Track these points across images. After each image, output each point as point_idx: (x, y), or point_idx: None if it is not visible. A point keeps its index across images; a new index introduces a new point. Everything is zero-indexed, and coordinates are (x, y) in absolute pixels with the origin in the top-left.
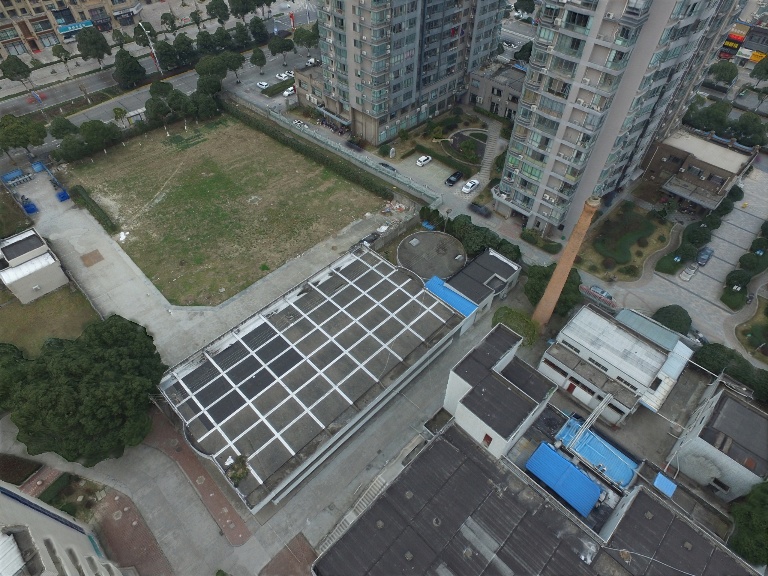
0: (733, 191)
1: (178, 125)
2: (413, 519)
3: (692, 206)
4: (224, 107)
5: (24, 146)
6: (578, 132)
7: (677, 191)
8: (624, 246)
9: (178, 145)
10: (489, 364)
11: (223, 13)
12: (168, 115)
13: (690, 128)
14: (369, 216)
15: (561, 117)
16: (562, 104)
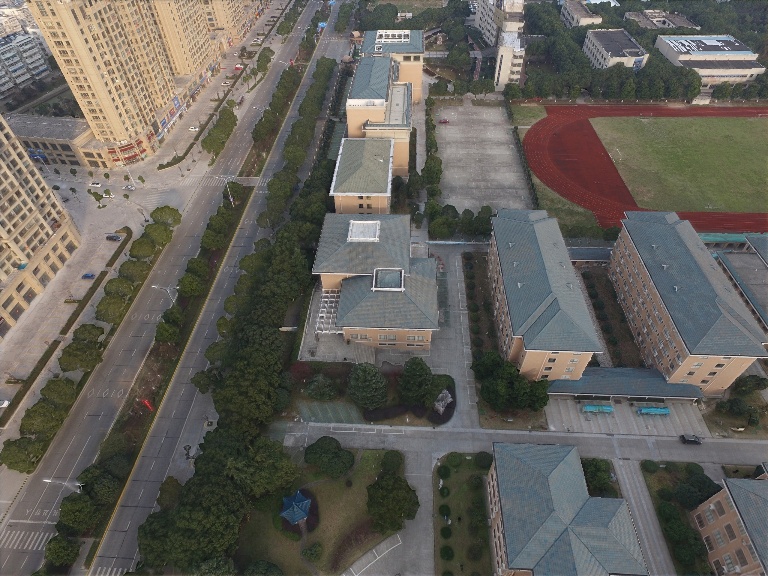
0: None
1: None
2: None
3: None
4: None
5: None
6: None
7: None
8: None
9: None
10: None
11: None
12: (357, 4)
13: None
14: (443, 0)
15: None
16: None
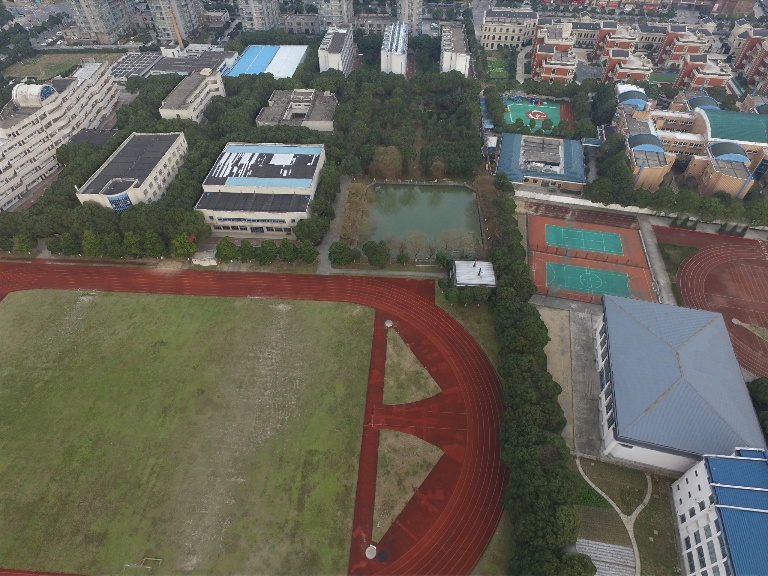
0: (226, 22)
1: (22, 61)
2: None
3: None
4: (37, 51)
5: None
6: (166, 7)
7: (211, 26)
8: (201, 39)
9: (31, 64)
10: None
11: None
12: None
13: (209, 11)
14: None
15: (160, 4)
16: (158, 1)
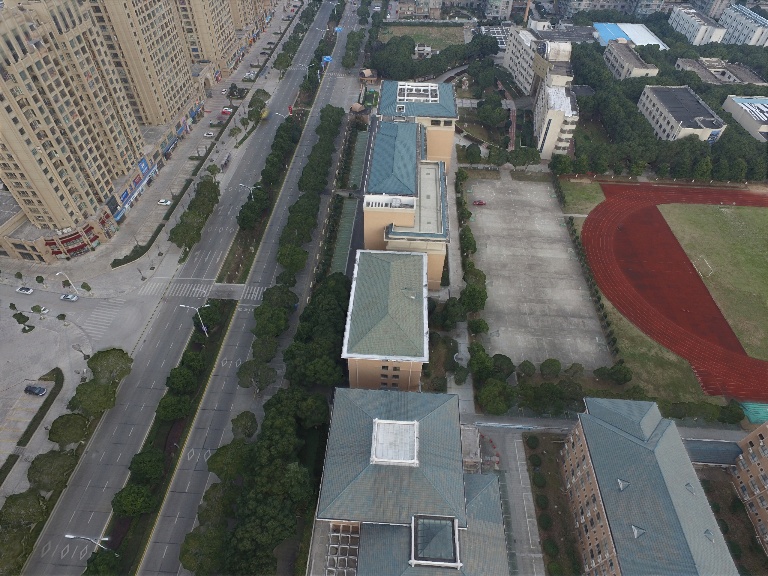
0: (526, 3)
1: None
2: (546, 35)
3: (521, 9)
4: None
5: None
6: None
7: (517, 6)
8: None
9: None
10: (535, 19)
11: (320, 0)
12: None
13: None
14: None
15: None
16: None
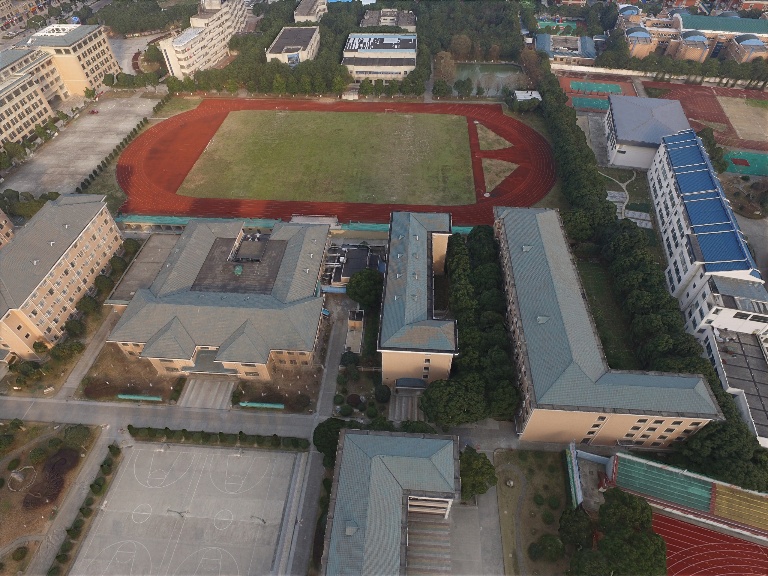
0: None
1: (156, 0)
2: None
3: None
4: None
5: (126, 5)
6: None
7: None
8: None
9: None
10: None
11: None
12: None
13: None
14: None
15: None
16: None
